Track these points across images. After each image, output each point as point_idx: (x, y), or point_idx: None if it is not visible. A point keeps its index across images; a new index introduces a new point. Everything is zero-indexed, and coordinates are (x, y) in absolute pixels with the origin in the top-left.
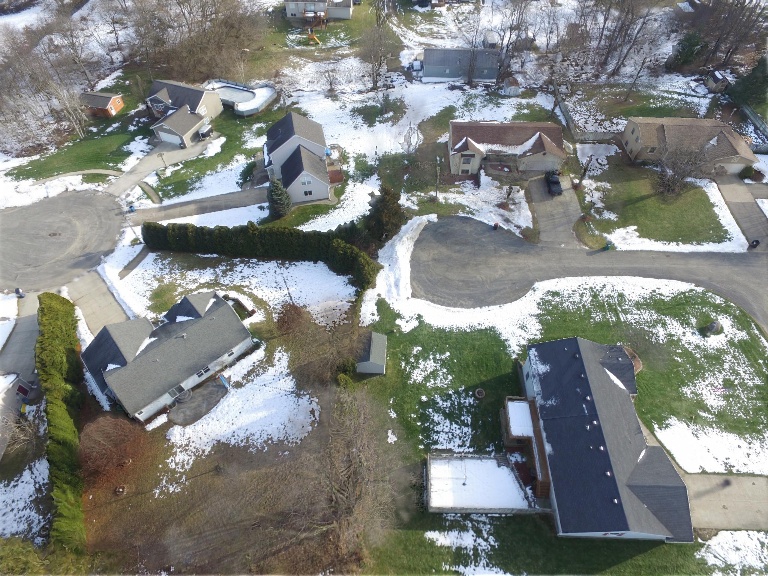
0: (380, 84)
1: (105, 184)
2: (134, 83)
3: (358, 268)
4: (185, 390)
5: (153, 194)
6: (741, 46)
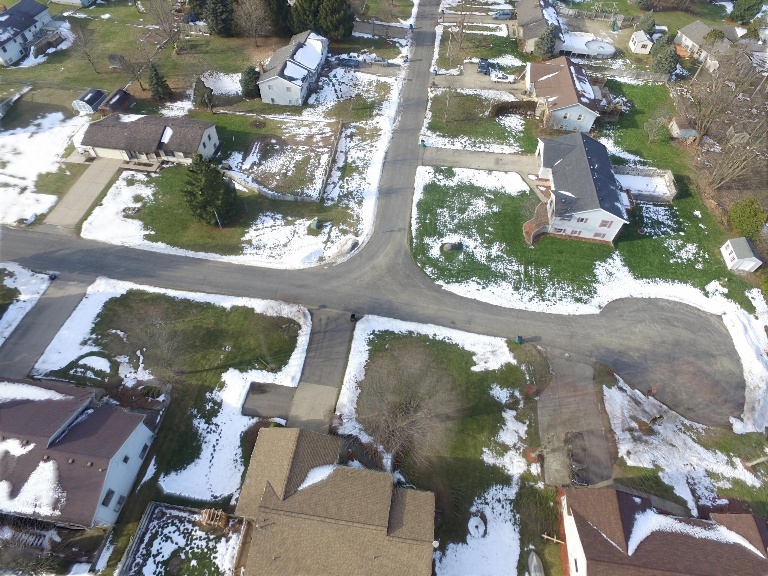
0: None
1: None
2: None
3: None
4: None
5: None
6: None
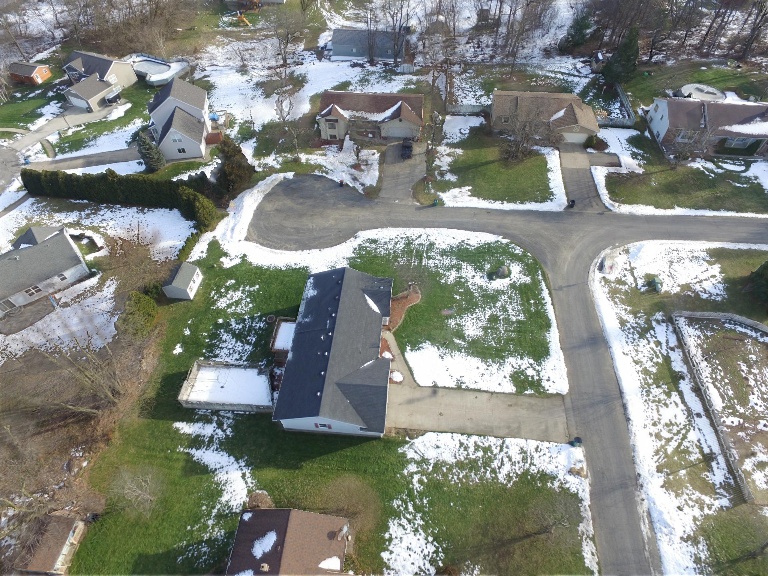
0: (291, 61)
1: (11, 140)
2: (67, 56)
3: (195, 211)
4: (16, 306)
5: (50, 150)
6: (642, 32)
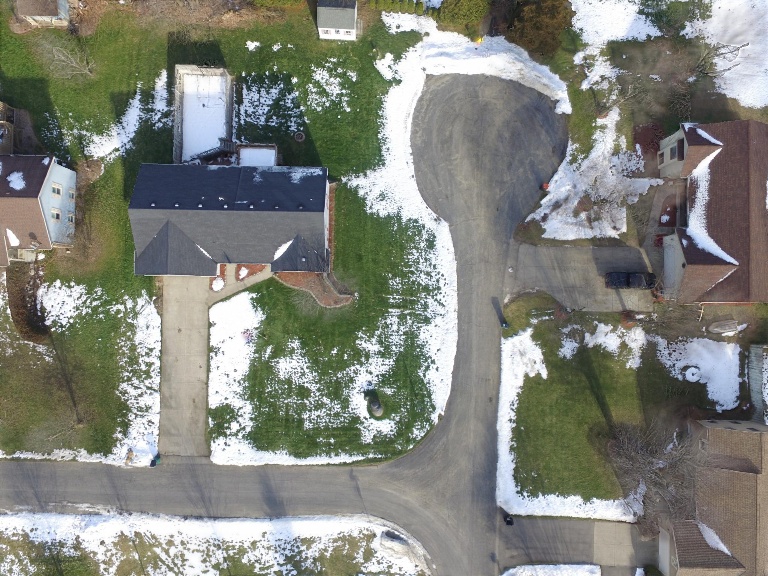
0: None
1: None
2: None
3: None
4: None
5: None
6: None
